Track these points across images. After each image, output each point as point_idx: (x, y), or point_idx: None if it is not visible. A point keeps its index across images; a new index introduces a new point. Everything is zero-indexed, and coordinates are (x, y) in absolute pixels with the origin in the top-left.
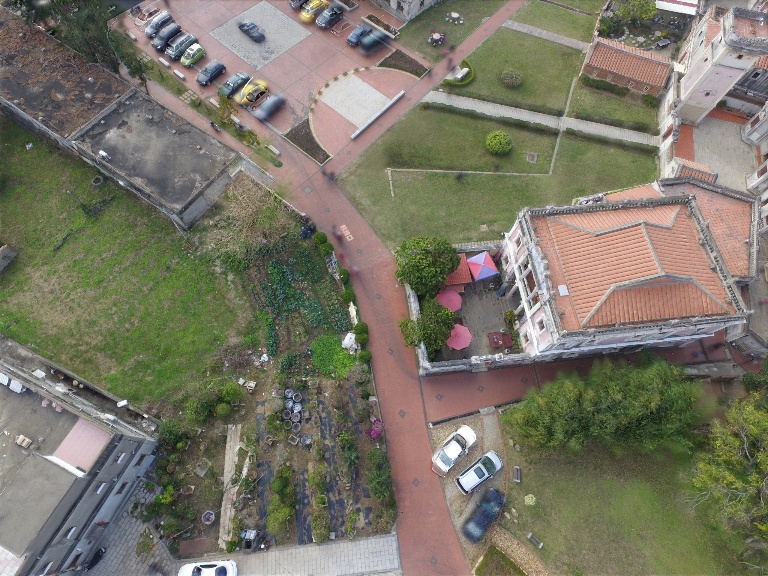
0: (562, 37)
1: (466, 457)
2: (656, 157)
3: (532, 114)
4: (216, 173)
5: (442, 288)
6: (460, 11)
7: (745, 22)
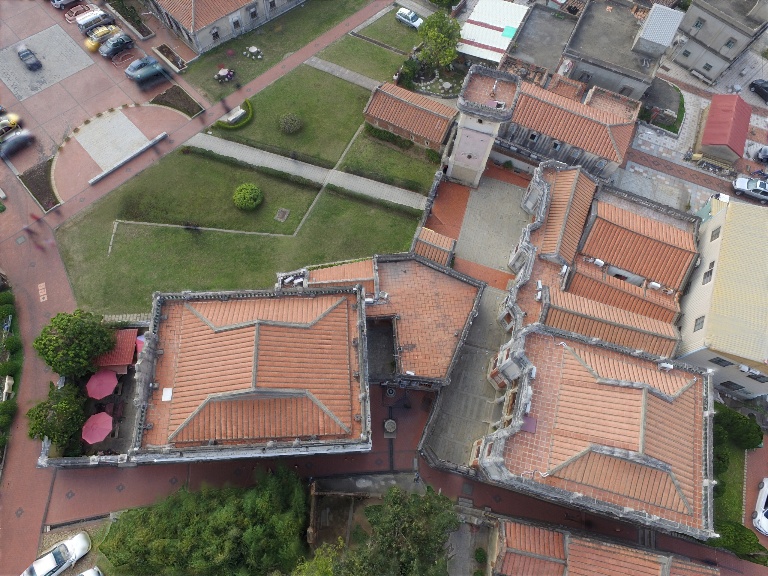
0: (364, 78)
1: (70, 571)
2: (420, 222)
3: (300, 165)
4: None
5: (91, 370)
6: (264, 44)
7: (488, 82)
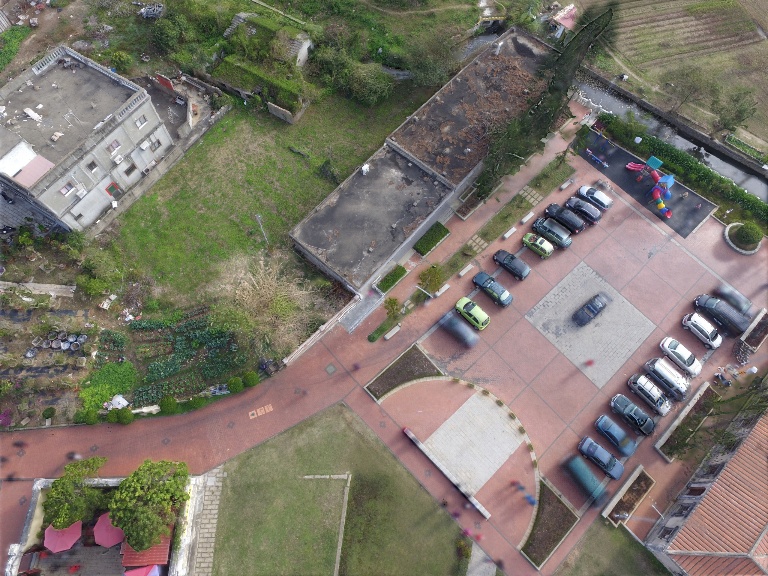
0: None
1: None
2: None
3: None
4: (335, 267)
5: None
6: None
7: None
